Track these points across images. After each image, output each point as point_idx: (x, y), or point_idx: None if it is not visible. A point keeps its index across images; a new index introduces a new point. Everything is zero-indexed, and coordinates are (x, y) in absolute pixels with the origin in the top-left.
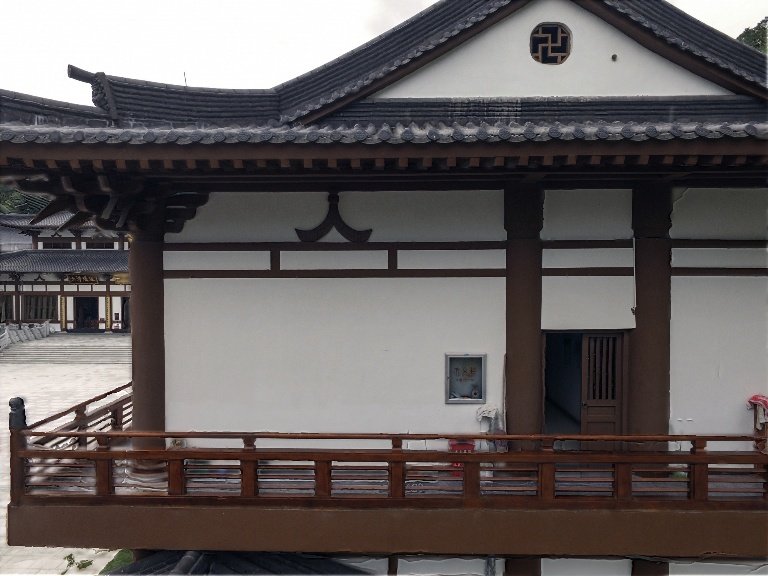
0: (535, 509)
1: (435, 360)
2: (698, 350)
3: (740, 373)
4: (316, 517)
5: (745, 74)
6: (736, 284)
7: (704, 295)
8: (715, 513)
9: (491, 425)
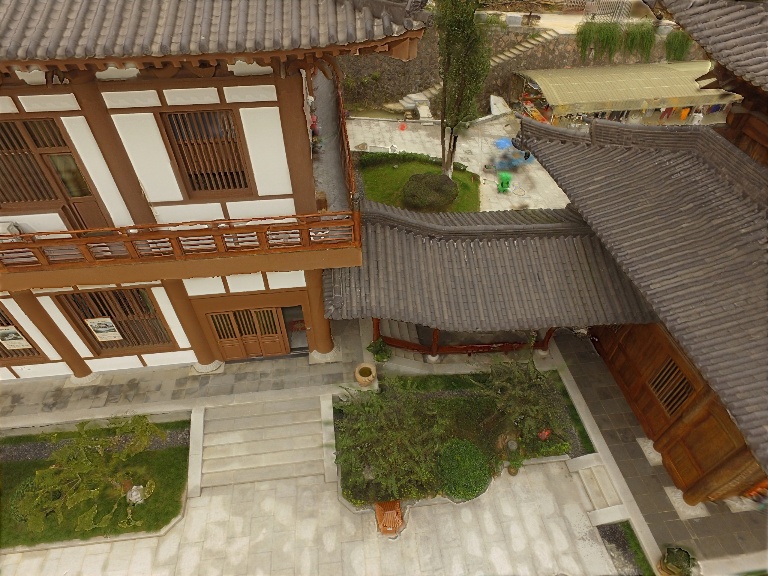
0: None
1: None
2: None
3: None
4: None
5: None
6: None
7: None
8: None
9: None
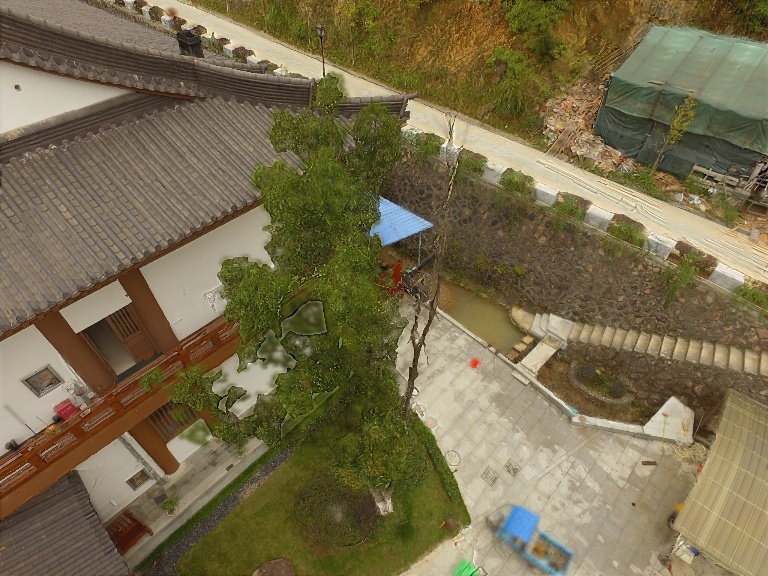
0: (118, 419)
1: (15, 386)
2: (170, 290)
3: (196, 285)
4: (1, 505)
5: (135, 84)
6: (176, 254)
7: (161, 267)
8: (196, 367)
9: (75, 390)
